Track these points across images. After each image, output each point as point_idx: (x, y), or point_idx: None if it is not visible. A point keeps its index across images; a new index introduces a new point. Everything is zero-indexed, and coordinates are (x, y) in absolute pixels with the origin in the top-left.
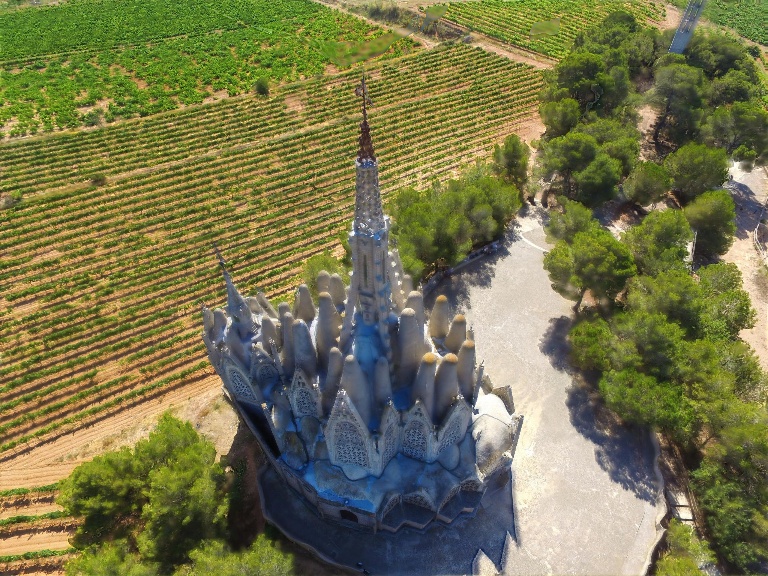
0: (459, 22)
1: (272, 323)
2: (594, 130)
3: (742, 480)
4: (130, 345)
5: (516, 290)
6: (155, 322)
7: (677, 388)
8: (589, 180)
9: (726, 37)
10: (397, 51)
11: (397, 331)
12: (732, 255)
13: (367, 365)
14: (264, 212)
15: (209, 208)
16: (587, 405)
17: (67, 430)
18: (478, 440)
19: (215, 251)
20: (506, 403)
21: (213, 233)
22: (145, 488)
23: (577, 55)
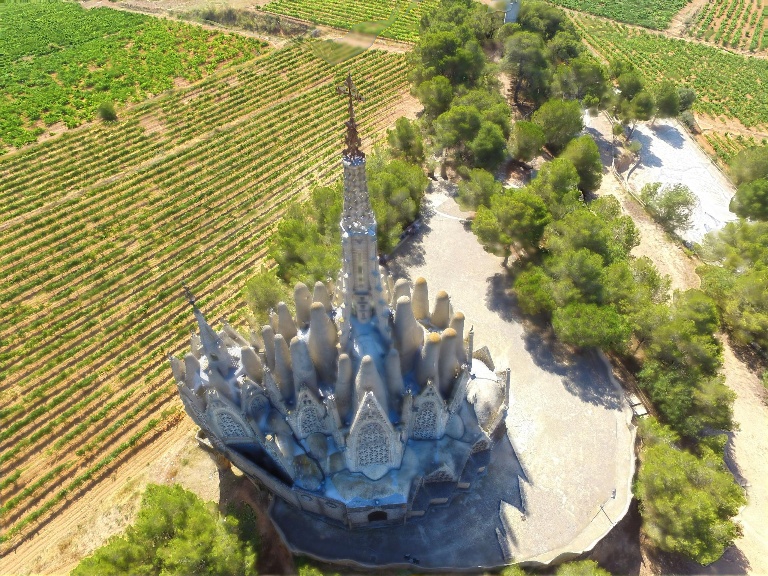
0: (301, 17)
1: (252, 351)
2: (469, 101)
3: (675, 368)
4: (51, 430)
5: (449, 261)
6: (73, 396)
7: (613, 308)
8: (482, 147)
9: (547, 4)
10: (246, 54)
11: (393, 322)
12: (602, 189)
13: (376, 362)
14: (160, 246)
15: (93, 256)
16: (543, 345)
17: (5, 550)
18: (475, 403)
19: (118, 300)
20: (485, 363)
21: (109, 281)
22: (154, 571)
23: (434, 35)
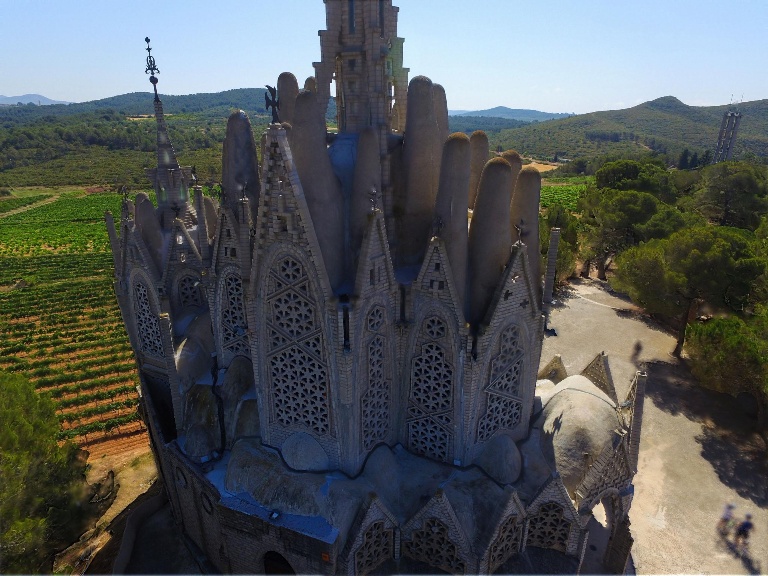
0: None
1: (216, 213)
2: None
3: None
4: (62, 396)
5: (583, 335)
6: (107, 378)
7: None
8: (657, 227)
9: (767, 166)
10: None
11: (402, 144)
12: None
13: (342, 171)
14: None
15: None
16: (744, 461)
17: None
18: (557, 429)
19: None
20: None
21: None
22: None
23: None
